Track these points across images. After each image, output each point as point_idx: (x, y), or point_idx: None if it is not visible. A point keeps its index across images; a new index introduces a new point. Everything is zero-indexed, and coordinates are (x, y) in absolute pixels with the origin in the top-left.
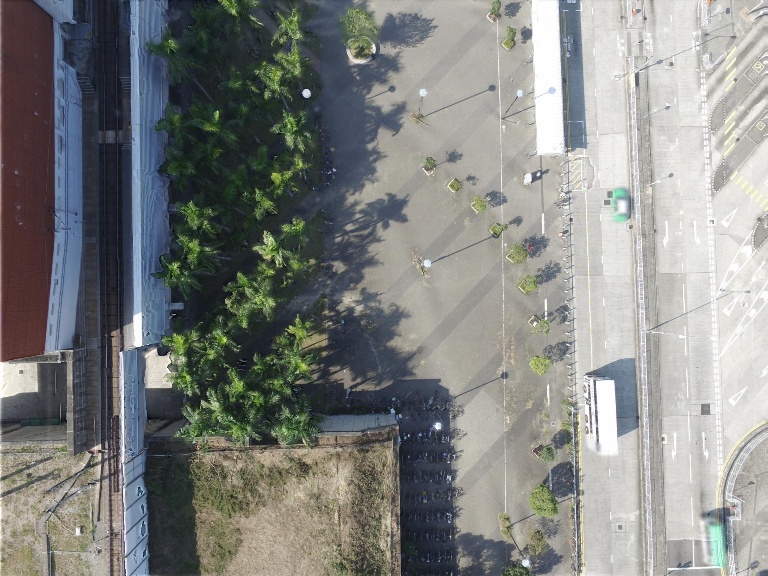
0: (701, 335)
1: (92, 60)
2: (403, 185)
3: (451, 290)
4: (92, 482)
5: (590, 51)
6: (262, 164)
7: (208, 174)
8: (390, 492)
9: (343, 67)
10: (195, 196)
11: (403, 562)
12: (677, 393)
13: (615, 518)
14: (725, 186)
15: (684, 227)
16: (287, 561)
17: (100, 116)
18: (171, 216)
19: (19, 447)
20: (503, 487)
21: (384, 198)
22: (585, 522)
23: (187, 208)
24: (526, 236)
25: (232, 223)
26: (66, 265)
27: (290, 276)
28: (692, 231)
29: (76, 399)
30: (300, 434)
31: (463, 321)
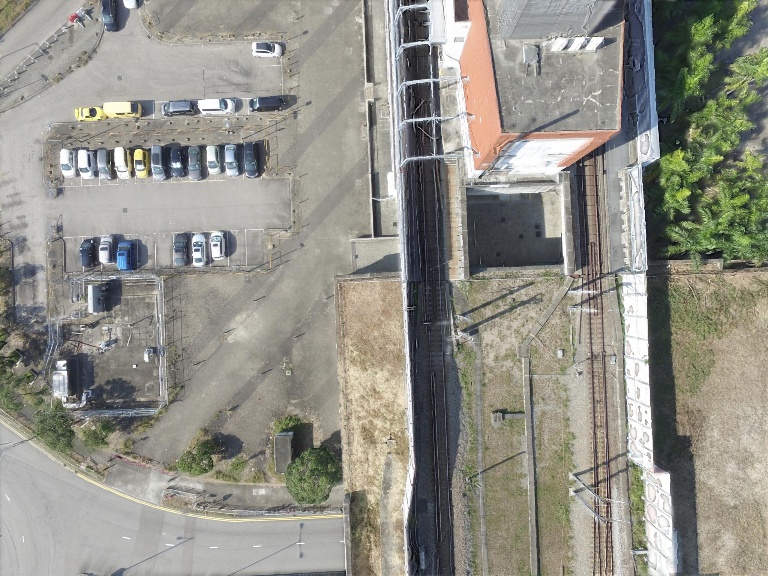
0: None
1: None
2: None
3: None
4: (571, 306)
5: None
6: None
7: None
8: None
9: None
10: None
11: None
12: None
13: None
14: None
15: None
16: (758, 381)
17: None
18: (629, 52)
19: (502, 273)
20: None
21: None
22: None
23: (700, 24)
24: None
25: None
26: None
27: None
28: None
29: None
30: None
31: None
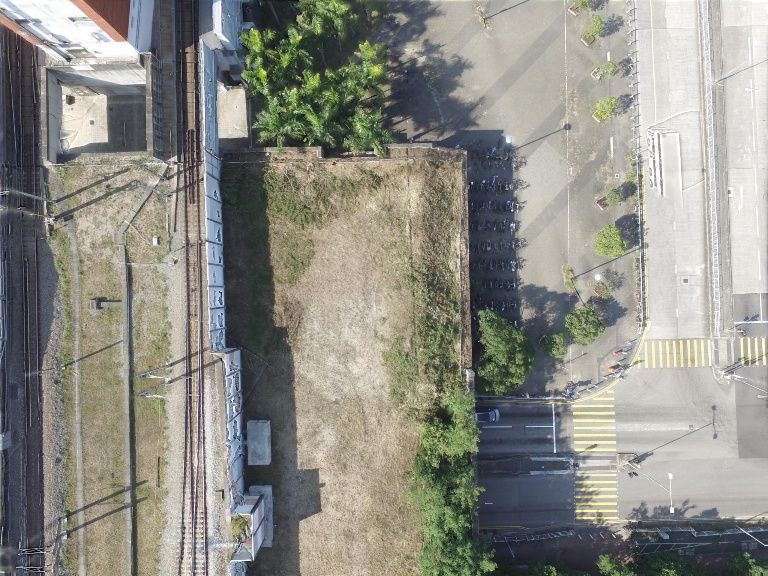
0: (767, 88)
1: None
2: None
3: (513, 42)
4: (168, 194)
5: None
6: None
7: None
8: (459, 212)
9: None
10: None
11: (471, 292)
12: (743, 146)
13: (680, 272)
14: None
15: None
16: (359, 273)
17: None
18: None
19: (98, 159)
20: (566, 239)
21: None
22: (649, 276)
23: None
24: None
25: None
26: None
27: (357, 7)
28: None
29: (154, 104)
30: (372, 144)
31: (525, 73)
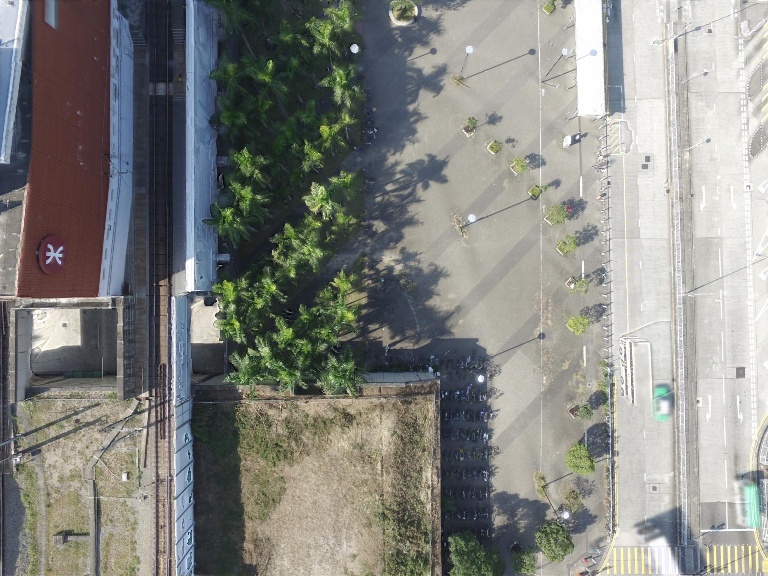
0: (737, 299)
1: (144, 12)
2: (443, 146)
3: (489, 251)
4: (139, 429)
5: (629, 17)
6: (310, 117)
7: (257, 126)
8: (431, 445)
9: (385, 29)
10: (246, 145)
11: (442, 516)
12: (712, 356)
13: (649, 479)
14: (762, 152)
15: (721, 192)
16: (330, 510)
17: (151, 68)
18: (219, 169)
19: (67, 393)
20: (539, 447)
21: (424, 159)
22: (619, 483)
23: (240, 155)
24: (564, 198)
25: (275, 180)
26: (118, 212)
27: (334, 231)
28: (729, 196)
29: (126, 345)
30: (345, 384)
31: (501, 281)
